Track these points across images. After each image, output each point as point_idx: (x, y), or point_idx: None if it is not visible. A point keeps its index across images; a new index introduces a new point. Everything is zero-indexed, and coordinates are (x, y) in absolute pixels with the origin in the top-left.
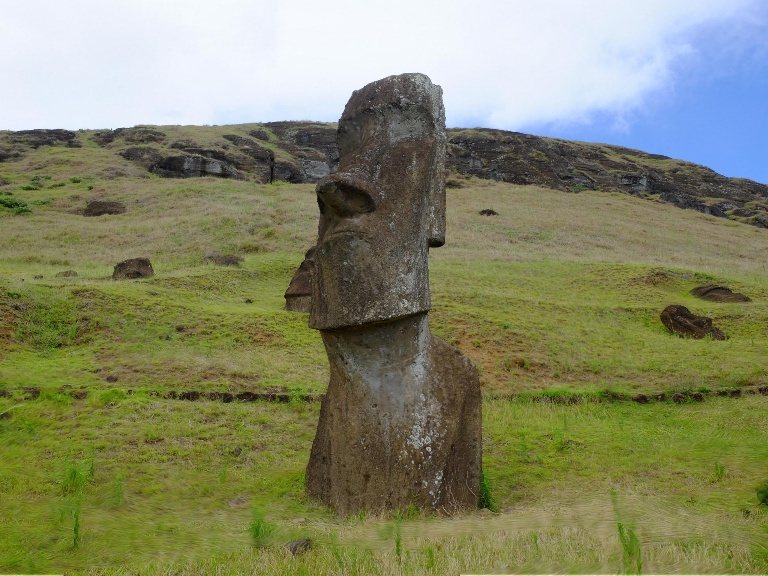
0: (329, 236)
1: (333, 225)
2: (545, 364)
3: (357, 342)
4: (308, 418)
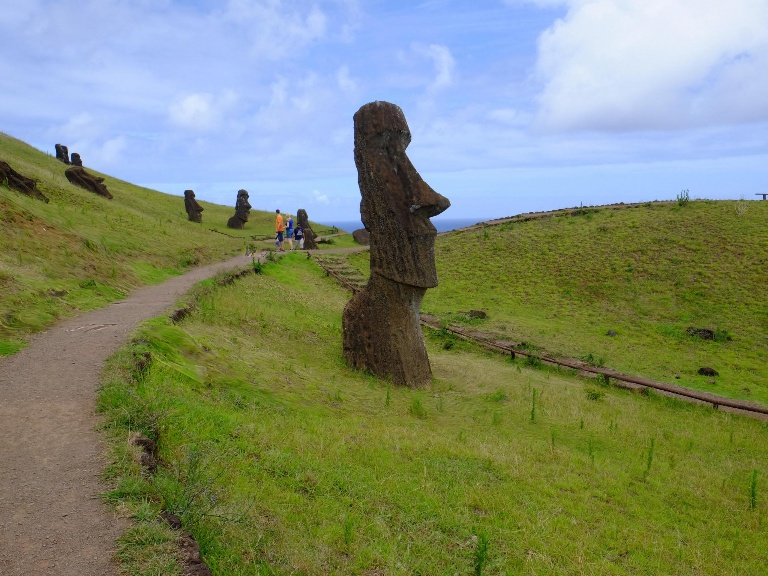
0: (428, 230)
1: (423, 221)
2: (94, 244)
3: (422, 293)
4: (224, 330)
